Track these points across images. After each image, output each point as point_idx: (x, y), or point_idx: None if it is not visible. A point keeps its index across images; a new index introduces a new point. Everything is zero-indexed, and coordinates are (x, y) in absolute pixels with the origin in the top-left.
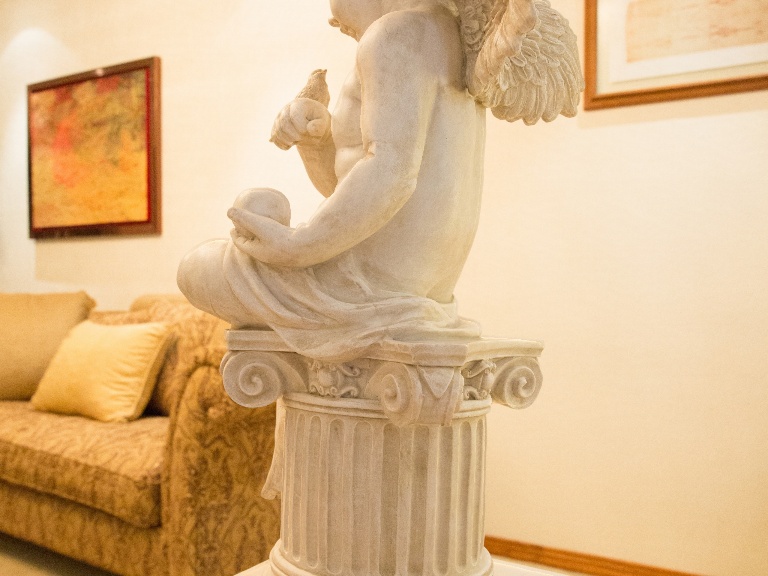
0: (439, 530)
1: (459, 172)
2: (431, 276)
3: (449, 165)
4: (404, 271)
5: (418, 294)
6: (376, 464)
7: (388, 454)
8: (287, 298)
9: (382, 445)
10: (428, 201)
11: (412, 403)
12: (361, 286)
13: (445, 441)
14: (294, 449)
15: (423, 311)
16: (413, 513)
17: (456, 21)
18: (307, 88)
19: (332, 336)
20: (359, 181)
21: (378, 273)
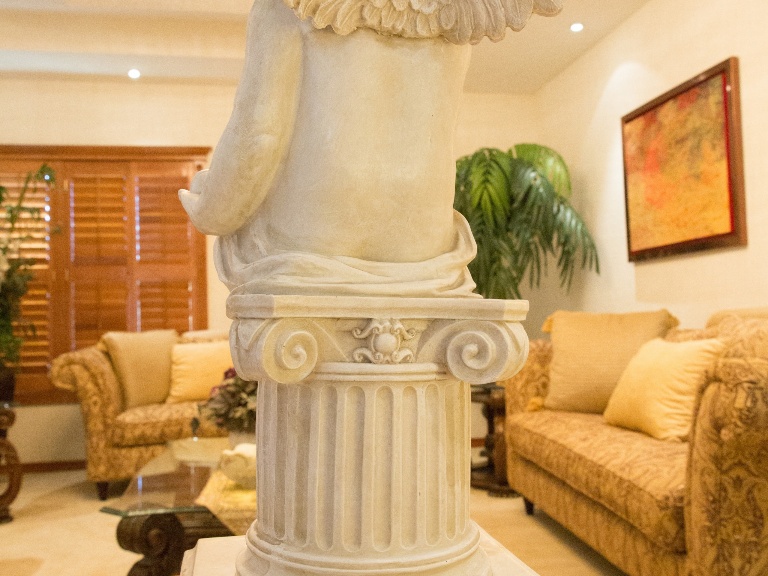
0: (326, 499)
1: (335, 118)
2: (331, 232)
3: (321, 113)
4: (295, 229)
5: (321, 252)
6: (273, 421)
7: (283, 413)
8: None
9: (276, 403)
10: (304, 154)
11: None
12: (259, 247)
13: (333, 405)
14: None
15: (292, 267)
16: (300, 476)
17: None
18: None
19: None
20: (216, 147)
21: (276, 233)
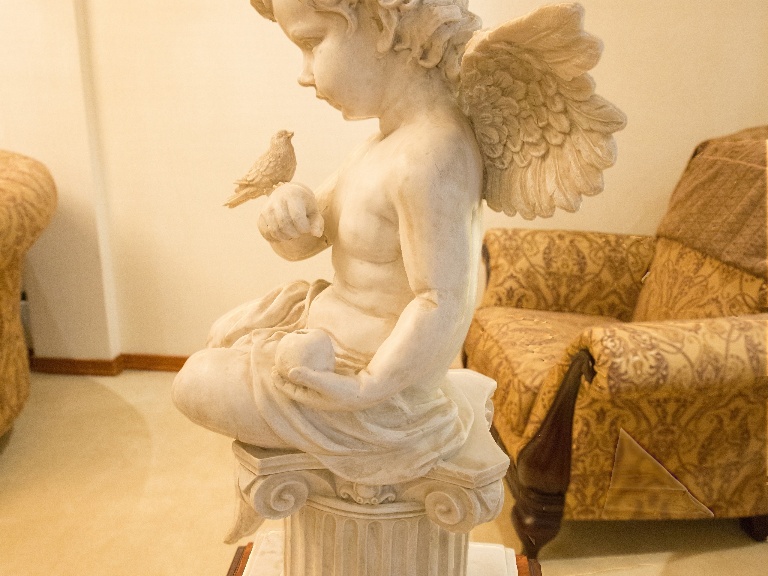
0: None
1: None
2: None
3: (473, 281)
4: (433, 383)
5: None
6: (412, 552)
7: (419, 540)
8: (331, 429)
9: (417, 536)
10: None
11: (472, 520)
12: (403, 409)
13: None
14: (321, 544)
15: None
16: None
17: (468, 123)
18: (276, 157)
19: (383, 462)
20: (427, 335)
21: (413, 391)
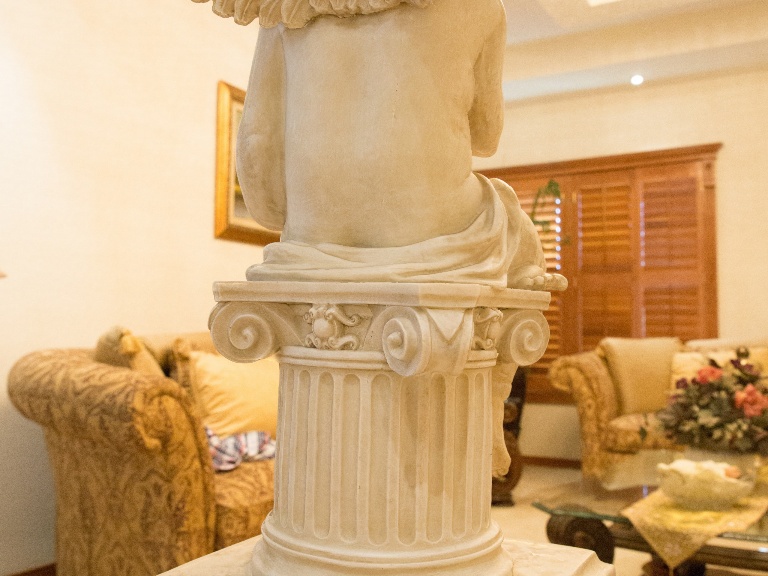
0: None
1: (298, 109)
2: (312, 220)
3: (290, 107)
4: None
5: (310, 240)
6: None
7: None
8: None
9: None
10: None
11: None
12: None
13: None
14: None
15: (273, 255)
16: None
17: None
18: None
19: None
20: None
21: None
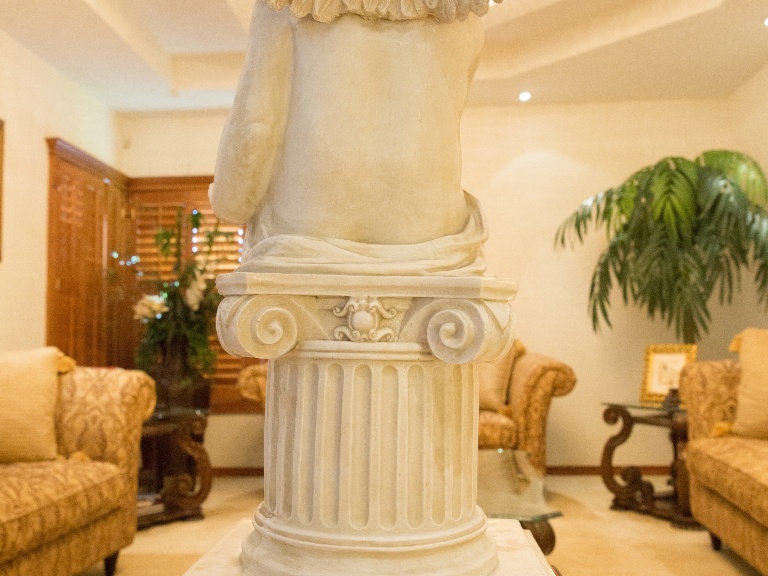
0: (309, 475)
1: (320, 103)
2: (322, 214)
3: (307, 99)
4: (291, 213)
5: (315, 234)
6: None
7: (279, 391)
8: None
9: (273, 381)
10: (294, 140)
11: None
12: (263, 232)
13: (316, 382)
14: None
15: (281, 248)
16: (288, 451)
17: None
18: None
19: None
20: None
21: (277, 219)
